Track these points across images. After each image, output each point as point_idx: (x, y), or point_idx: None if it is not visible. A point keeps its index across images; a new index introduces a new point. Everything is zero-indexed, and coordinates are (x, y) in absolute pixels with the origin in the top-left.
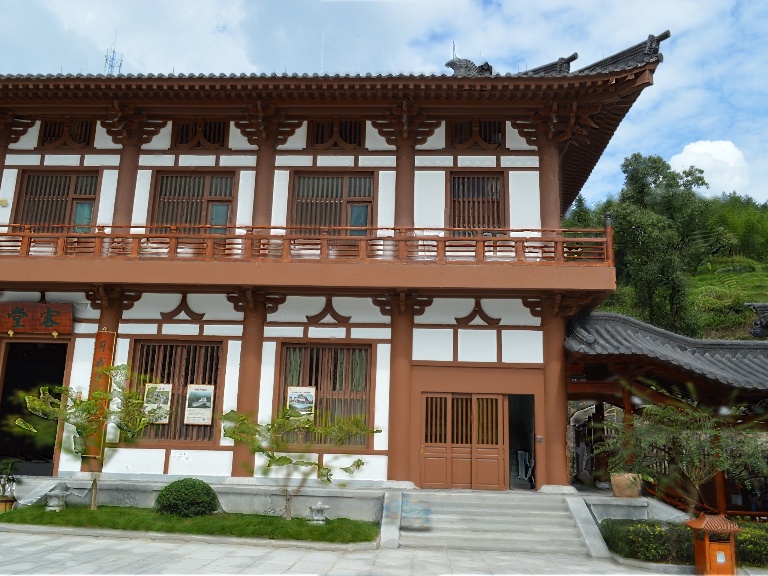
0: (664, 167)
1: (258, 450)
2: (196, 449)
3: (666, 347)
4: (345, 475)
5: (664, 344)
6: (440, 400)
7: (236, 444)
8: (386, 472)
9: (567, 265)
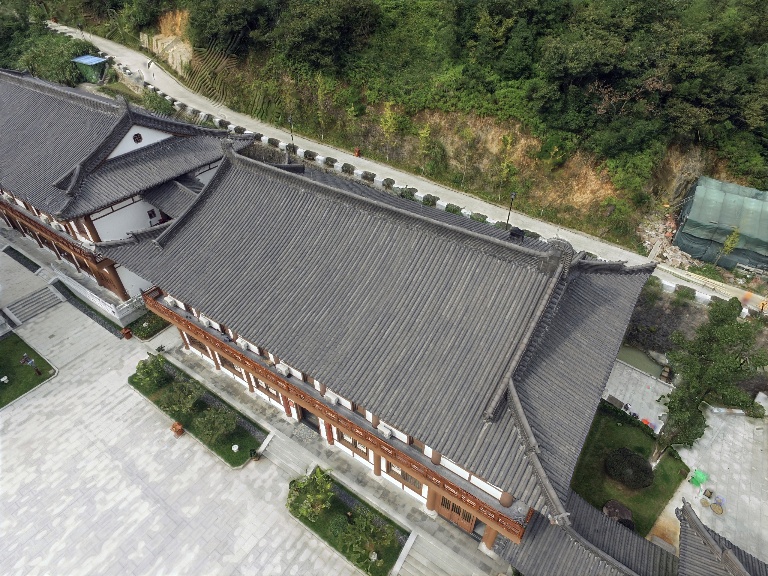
0: (743, 337)
1: (382, 470)
2: (362, 457)
3: (566, 538)
4: (412, 494)
5: (568, 534)
6: (448, 500)
7: (374, 465)
8: (426, 502)
9: (498, 524)
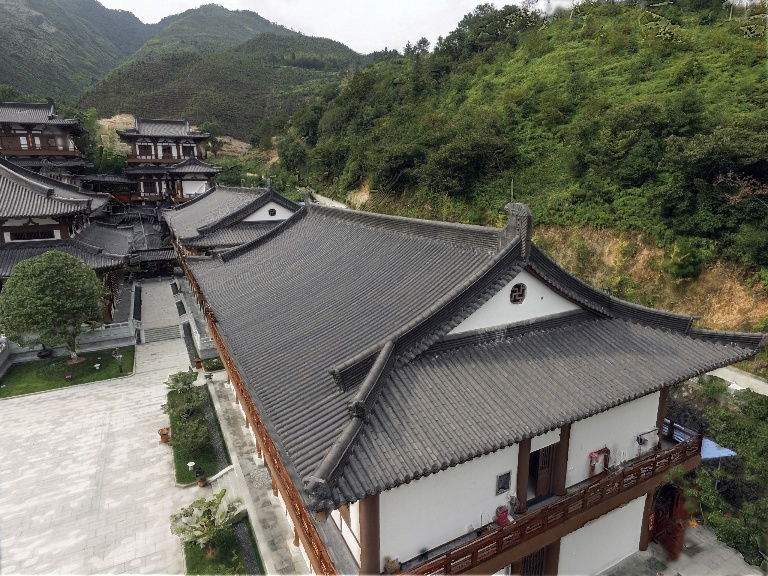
0: None
1: None
2: None
3: None
4: None
5: None
6: None
7: None
8: None
9: None
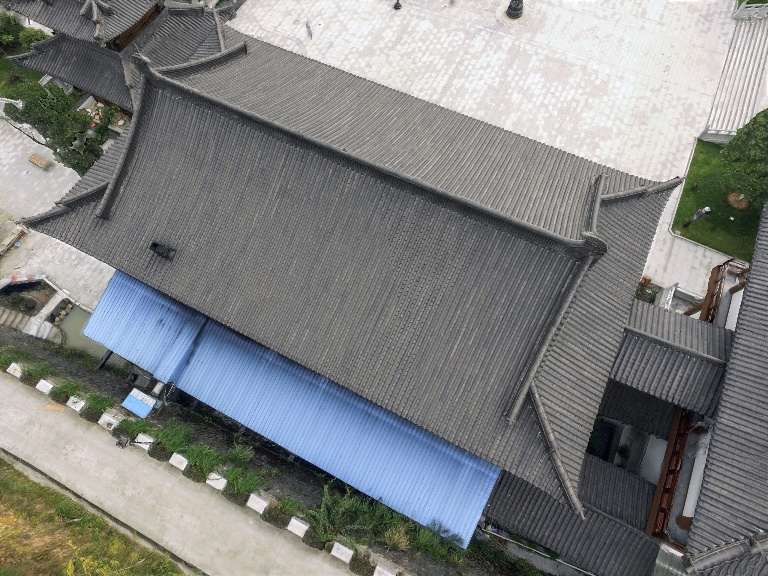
0: None
1: None
2: None
3: None
4: None
5: None
6: None
7: None
8: None
9: None
